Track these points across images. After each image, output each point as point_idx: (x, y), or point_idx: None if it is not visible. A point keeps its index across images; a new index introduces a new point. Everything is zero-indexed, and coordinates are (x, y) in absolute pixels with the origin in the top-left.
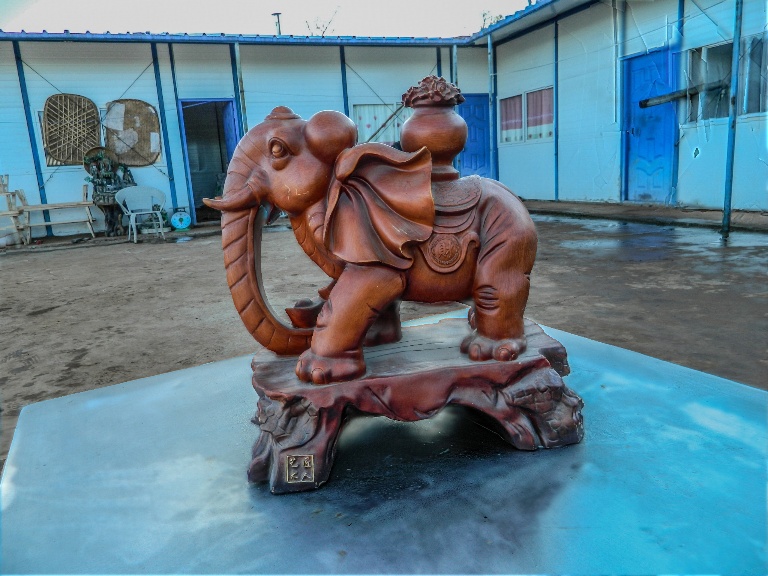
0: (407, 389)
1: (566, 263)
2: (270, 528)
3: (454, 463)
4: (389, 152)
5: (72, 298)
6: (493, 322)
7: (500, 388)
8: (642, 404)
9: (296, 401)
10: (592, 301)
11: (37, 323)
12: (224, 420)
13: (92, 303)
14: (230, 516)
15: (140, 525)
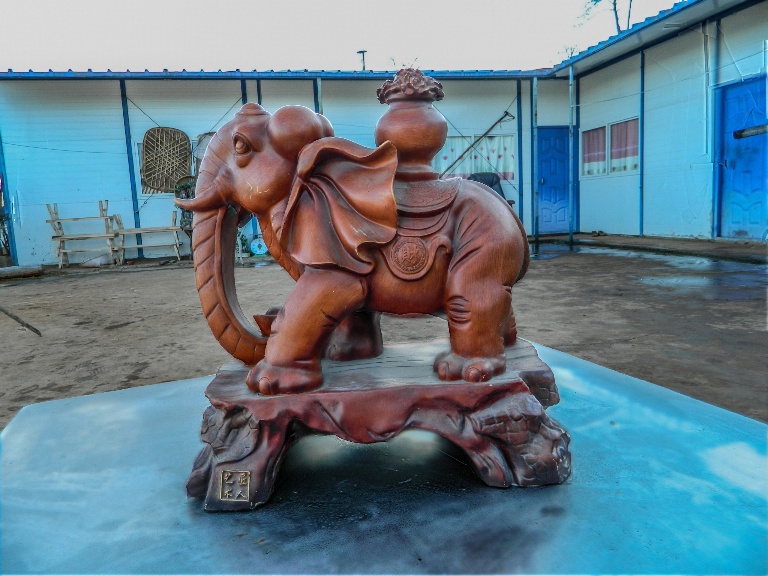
0: (361, 407)
1: (642, 299)
2: (184, 547)
3: (410, 495)
4: (349, 146)
5: (147, 315)
6: (464, 338)
7: (468, 413)
8: (652, 445)
9: (237, 411)
10: (665, 340)
11: (111, 336)
12: (196, 431)
13: (163, 320)
14: (152, 530)
15: (63, 531)
